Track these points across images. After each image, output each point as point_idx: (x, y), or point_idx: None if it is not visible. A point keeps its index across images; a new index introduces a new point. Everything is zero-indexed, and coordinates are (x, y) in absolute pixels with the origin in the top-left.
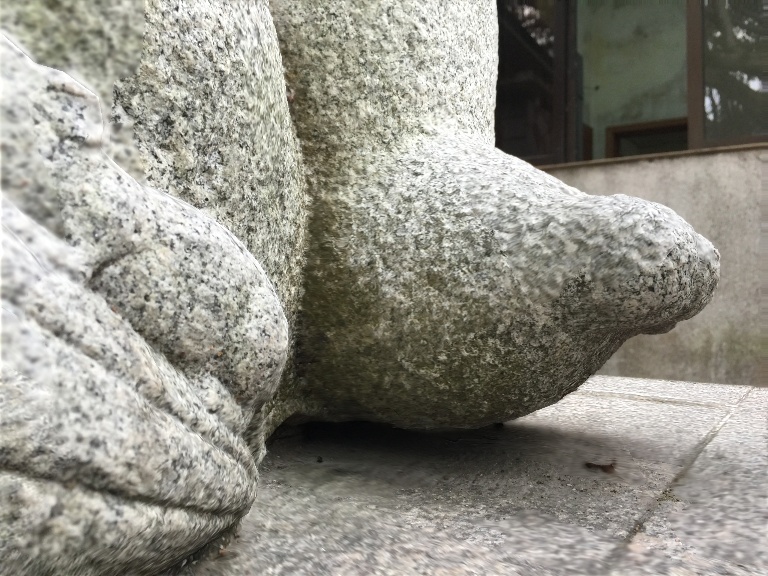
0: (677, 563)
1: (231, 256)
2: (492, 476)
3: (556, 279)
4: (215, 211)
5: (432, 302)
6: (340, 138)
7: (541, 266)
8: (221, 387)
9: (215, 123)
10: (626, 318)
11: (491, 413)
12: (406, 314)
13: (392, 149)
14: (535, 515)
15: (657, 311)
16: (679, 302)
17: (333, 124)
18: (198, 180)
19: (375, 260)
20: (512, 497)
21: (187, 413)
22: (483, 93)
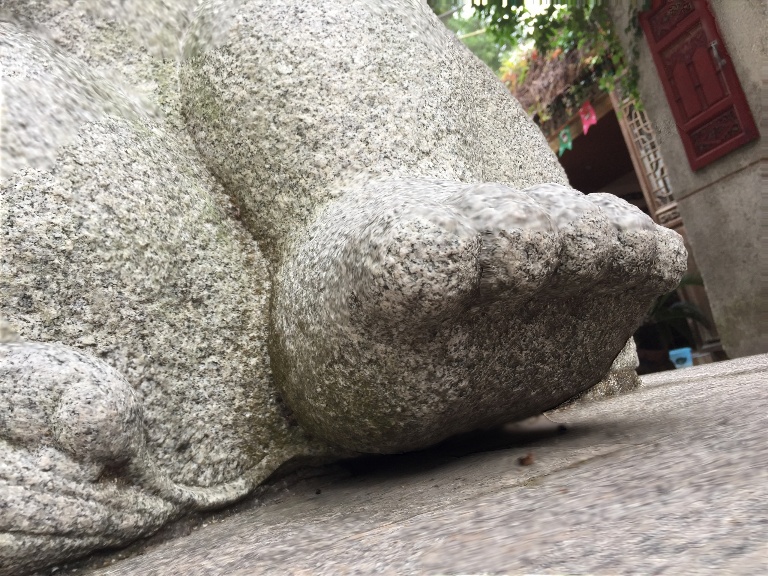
0: (351, 545)
1: (41, 370)
2: (409, 486)
3: (342, 301)
4: (92, 336)
5: (302, 346)
6: (275, 230)
7: (336, 293)
8: (57, 453)
9: (69, 283)
10: (399, 318)
11: (384, 428)
12: (295, 360)
13: (307, 223)
14: (353, 517)
15: (414, 304)
16: (426, 289)
17: (267, 221)
18: (70, 321)
19: (282, 322)
20: (379, 503)
21: (11, 474)
22: (404, 133)
